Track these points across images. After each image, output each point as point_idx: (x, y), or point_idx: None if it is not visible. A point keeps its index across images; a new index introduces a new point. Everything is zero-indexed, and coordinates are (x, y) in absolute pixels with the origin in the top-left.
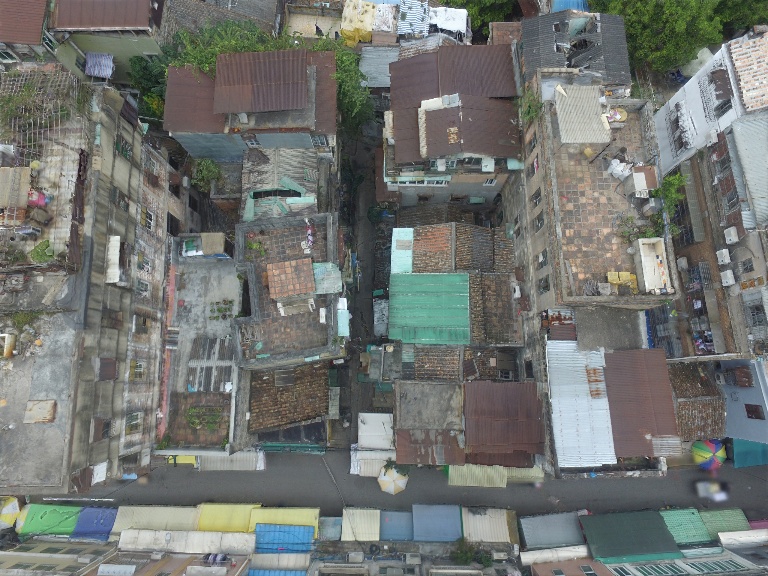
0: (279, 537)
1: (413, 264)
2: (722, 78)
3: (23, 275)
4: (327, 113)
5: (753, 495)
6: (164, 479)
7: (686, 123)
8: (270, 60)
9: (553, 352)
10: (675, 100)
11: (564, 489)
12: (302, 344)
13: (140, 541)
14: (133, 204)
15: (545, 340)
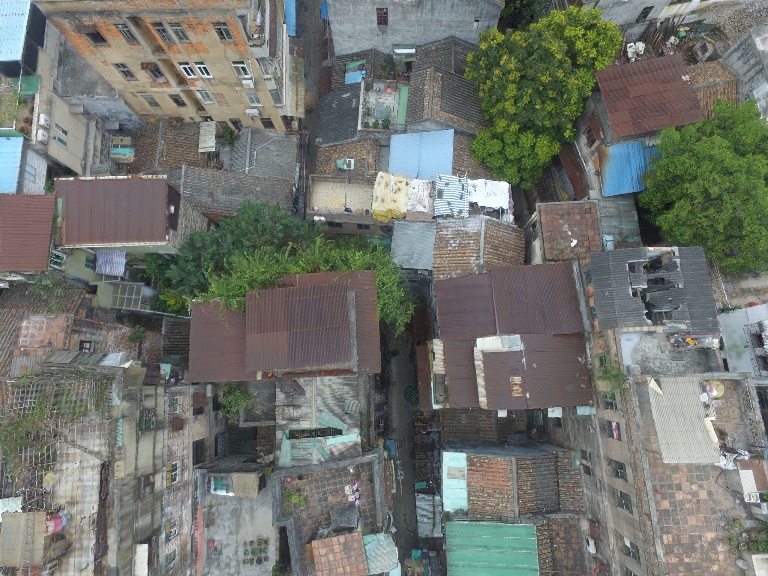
0: None
1: (469, 500)
2: None
3: None
4: (370, 347)
5: None
6: None
7: None
8: (306, 298)
9: None
10: (755, 313)
11: None
12: None
13: None
14: (158, 475)
15: None
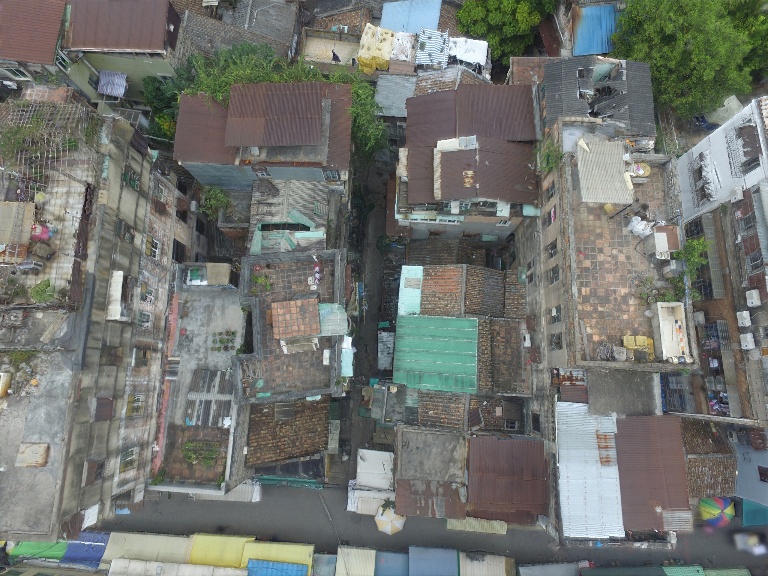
0: (271, 574)
1: (421, 304)
2: (751, 135)
3: (22, 311)
4: (340, 148)
5: (760, 552)
6: (158, 504)
7: (710, 174)
8: (285, 92)
9: (563, 414)
10: (699, 149)
11: None
12: (304, 384)
13: (130, 571)
14: (139, 235)
15: (555, 400)
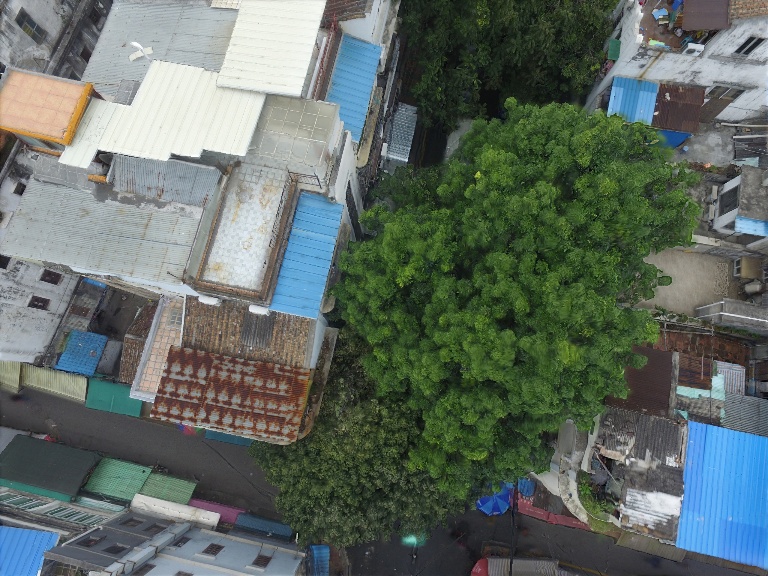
0: None
1: None
2: None
3: None
4: None
5: None
6: None
7: None
8: None
9: None
10: None
11: (66, 416)
12: None
13: None
14: None
15: None
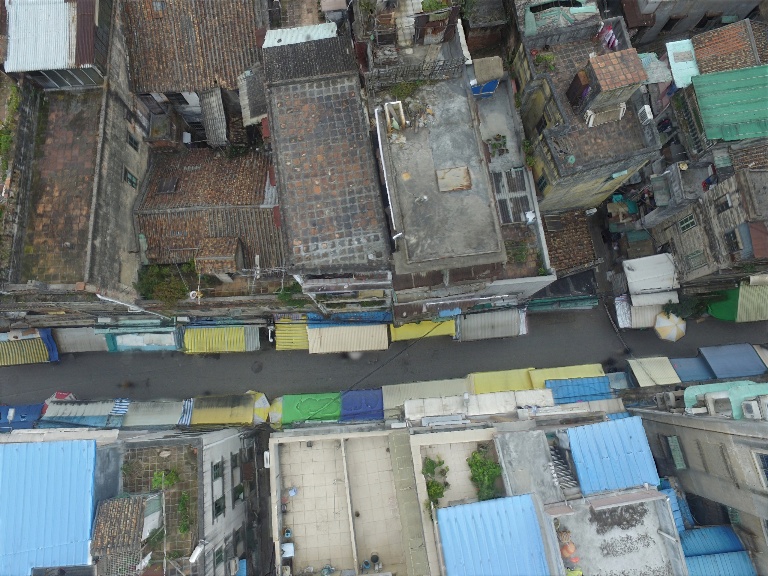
0: (574, 391)
1: (702, 72)
2: None
3: (394, 45)
4: None
5: None
6: (407, 364)
7: None
8: None
9: None
10: None
11: None
12: (618, 153)
13: (428, 409)
14: None
15: None
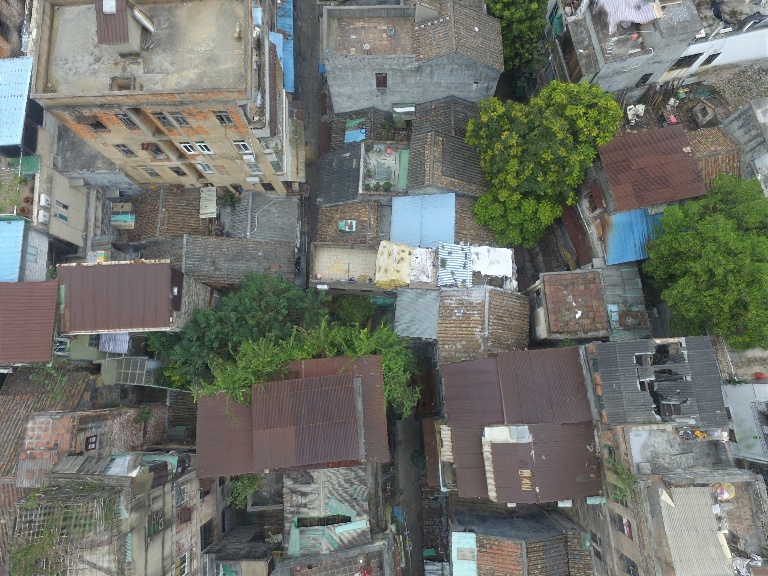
0: None
1: None
2: None
3: None
4: (377, 435)
5: None
6: None
7: None
8: (312, 390)
9: None
10: (763, 391)
11: None
12: None
13: None
14: (167, 575)
15: None
